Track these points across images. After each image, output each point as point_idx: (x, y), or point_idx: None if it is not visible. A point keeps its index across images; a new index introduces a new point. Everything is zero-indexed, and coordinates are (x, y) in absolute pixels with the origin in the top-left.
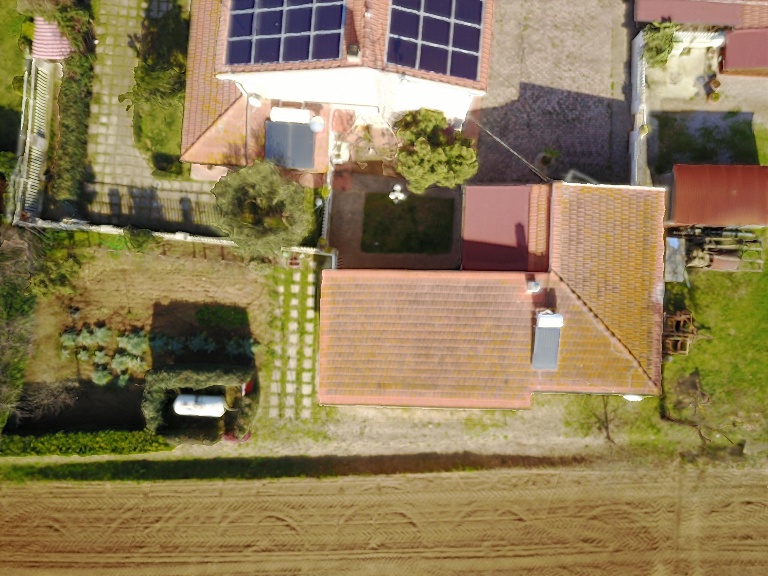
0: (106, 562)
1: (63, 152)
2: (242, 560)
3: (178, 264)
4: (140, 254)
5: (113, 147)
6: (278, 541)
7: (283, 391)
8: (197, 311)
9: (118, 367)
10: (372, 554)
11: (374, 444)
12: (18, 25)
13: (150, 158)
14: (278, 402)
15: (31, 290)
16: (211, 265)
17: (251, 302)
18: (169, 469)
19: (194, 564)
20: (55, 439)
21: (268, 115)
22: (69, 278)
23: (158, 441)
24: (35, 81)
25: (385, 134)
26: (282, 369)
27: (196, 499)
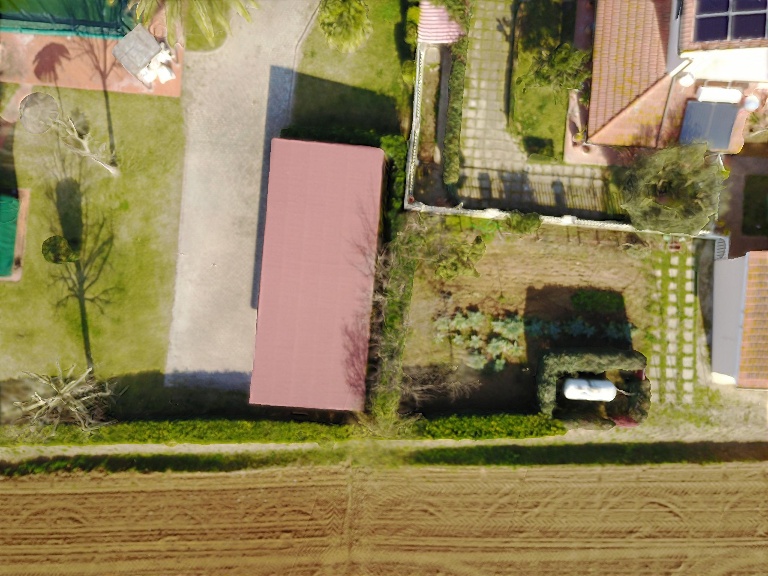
0: (484, 547)
1: (453, 136)
2: (625, 546)
3: (551, 248)
4: (512, 238)
5: (482, 131)
6: (662, 527)
7: (662, 376)
8: (572, 295)
9: (494, 351)
10: (760, 542)
11: (757, 430)
12: (388, 10)
13: (521, 142)
14: (658, 387)
15: (439, 273)
16: (585, 249)
17: (626, 286)
18: (542, 454)
19: (576, 550)
20: (450, 423)
21: (689, 95)
22: (473, 261)
23: (555, 425)
24: (419, 65)
25: (766, 116)
26: (661, 354)
27: (574, 484)
